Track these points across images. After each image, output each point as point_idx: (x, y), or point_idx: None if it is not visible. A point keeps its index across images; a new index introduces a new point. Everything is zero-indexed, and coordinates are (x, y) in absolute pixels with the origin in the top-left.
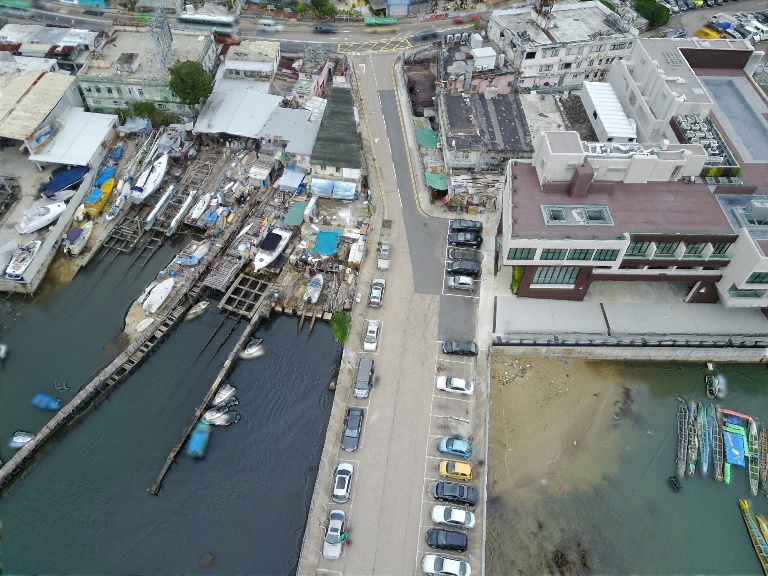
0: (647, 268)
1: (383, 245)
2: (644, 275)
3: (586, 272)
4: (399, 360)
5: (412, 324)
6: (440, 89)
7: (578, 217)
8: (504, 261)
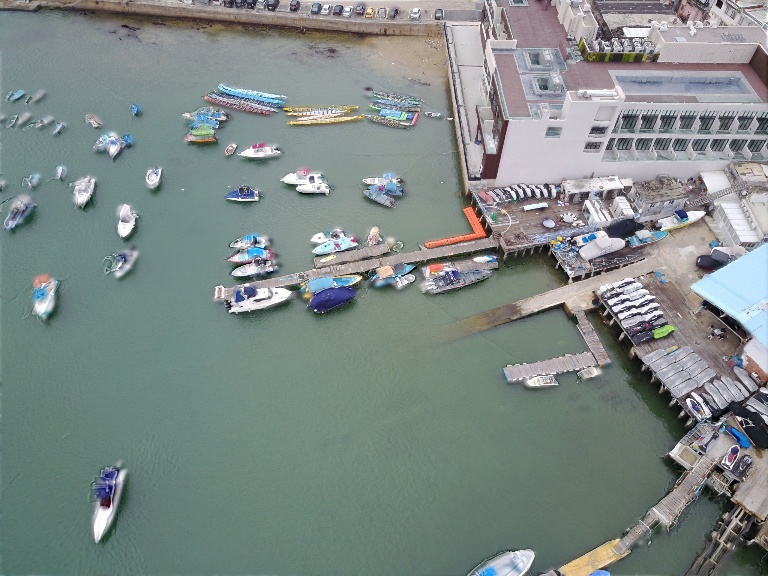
0: None
1: None
2: None
3: None
4: (430, 1)
5: (454, 3)
6: None
7: None
8: None
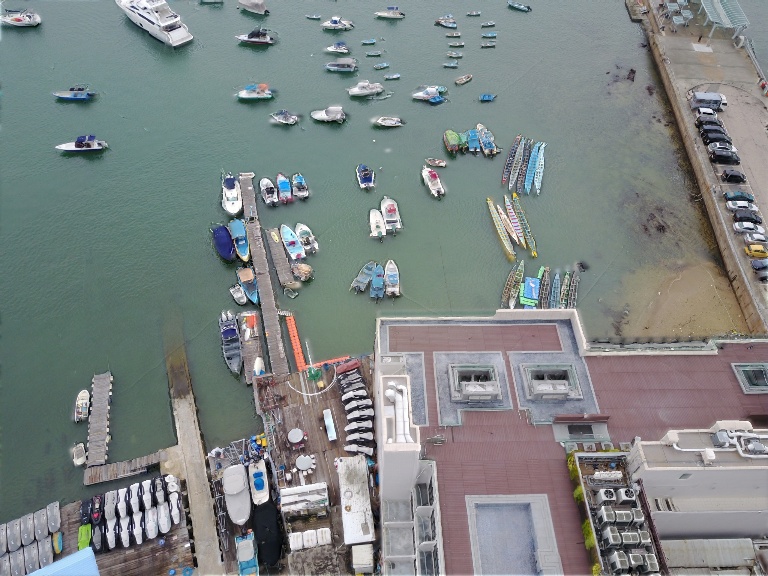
0: None
1: None
2: None
3: None
4: None
5: None
6: None
7: None
8: None
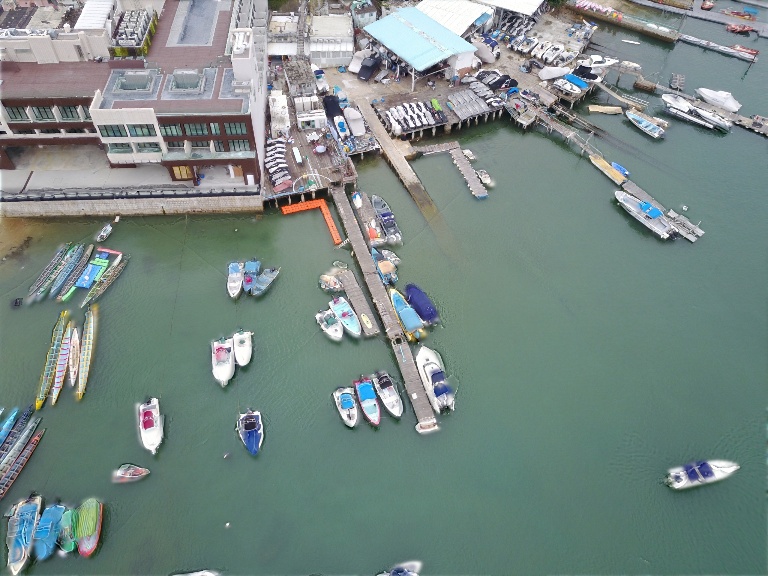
0: (40, 132)
1: None
2: (39, 139)
3: None
4: None
5: None
6: None
7: None
8: None
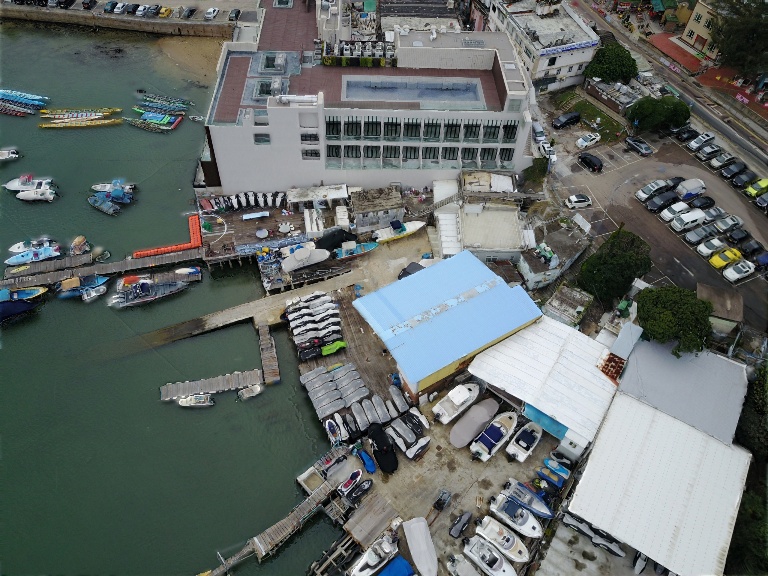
0: None
1: None
2: None
3: None
4: (233, 1)
5: (256, 4)
6: None
7: None
8: None
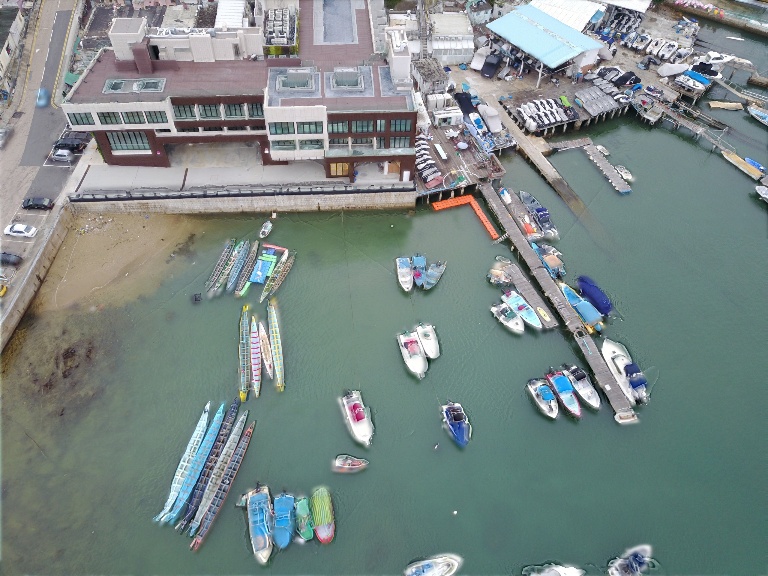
0: (203, 130)
1: (0, 129)
2: (202, 136)
3: (151, 136)
4: None
5: (5, 189)
6: (95, 3)
7: (135, 87)
8: (71, 127)
